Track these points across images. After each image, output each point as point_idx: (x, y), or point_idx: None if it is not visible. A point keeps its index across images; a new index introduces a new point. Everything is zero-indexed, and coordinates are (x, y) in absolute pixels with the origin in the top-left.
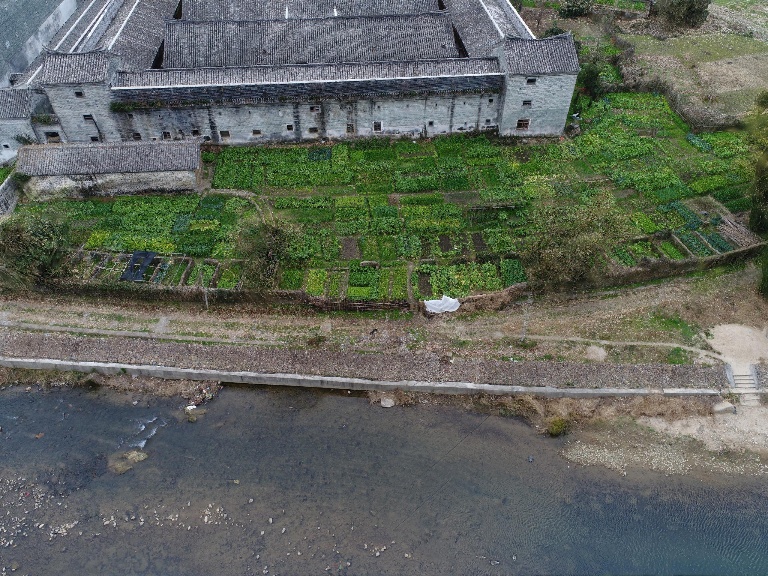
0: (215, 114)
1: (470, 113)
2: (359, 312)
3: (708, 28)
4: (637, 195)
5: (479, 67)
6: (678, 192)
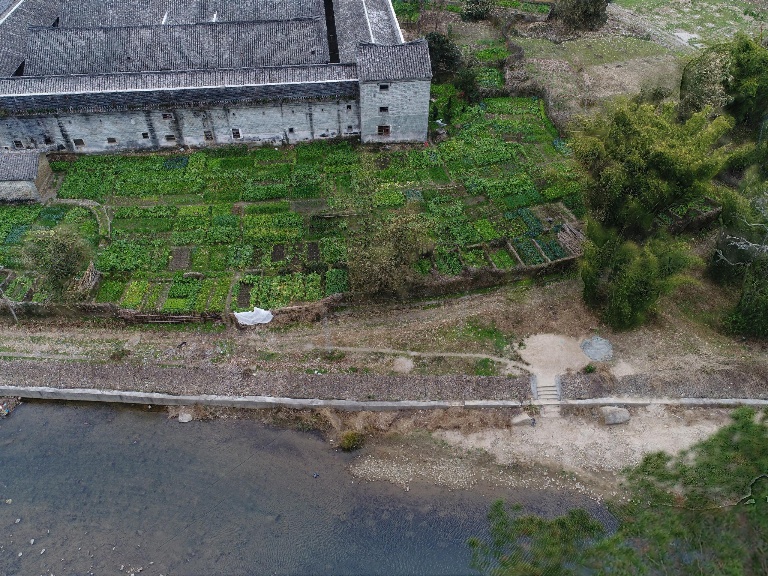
0: (65, 122)
1: (330, 120)
2: (171, 325)
3: (606, 31)
4: (487, 202)
5: (337, 73)
6: (528, 199)
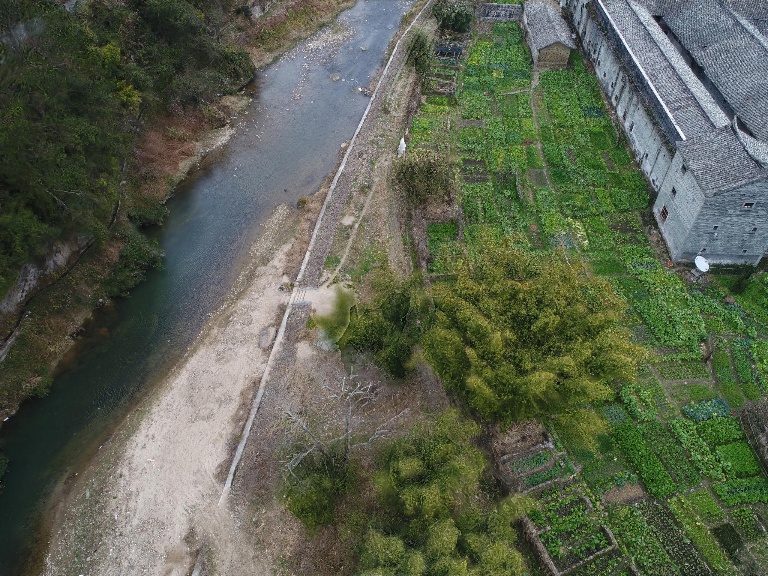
0: None
1: None
2: None
3: None
4: None
5: None
6: None
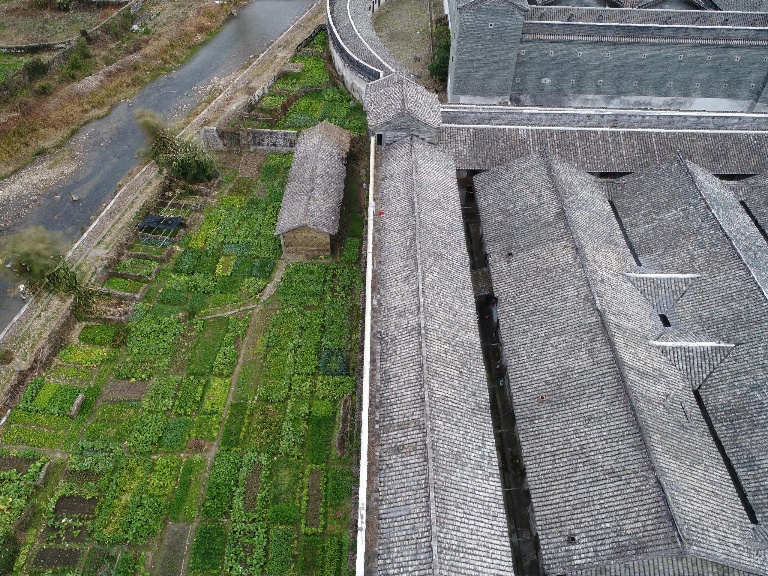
0: None
1: None
2: None
3: None
4: None
5: None
6: None
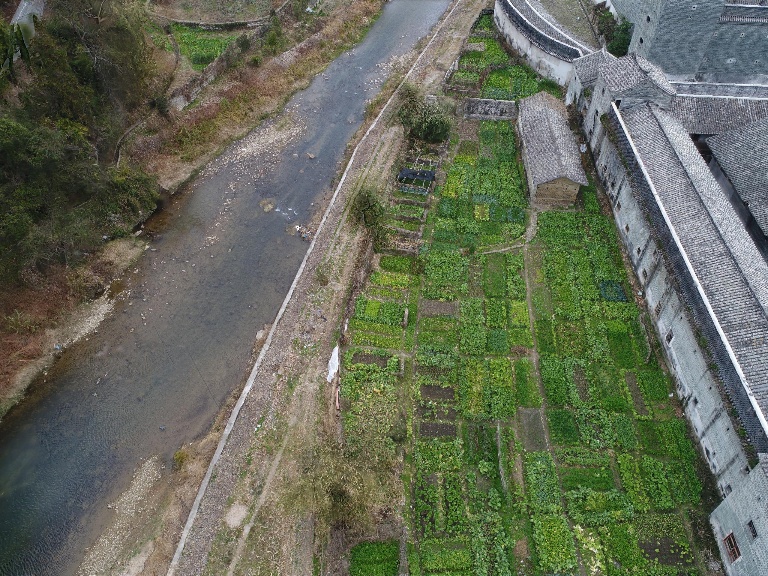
0: None
1: (725, 449)
2: None
3: None
4: None
5: None
6: None
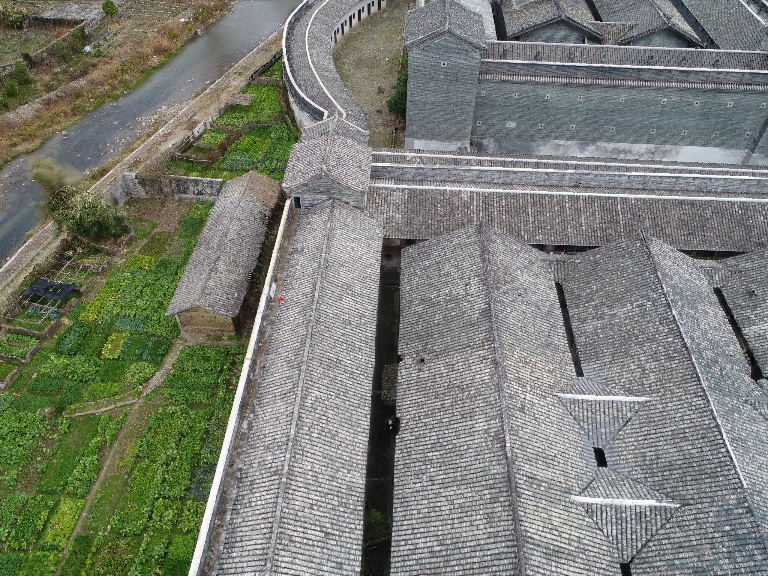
0: None
1: None
2: None
3: None
4: None
5: None
6: None
